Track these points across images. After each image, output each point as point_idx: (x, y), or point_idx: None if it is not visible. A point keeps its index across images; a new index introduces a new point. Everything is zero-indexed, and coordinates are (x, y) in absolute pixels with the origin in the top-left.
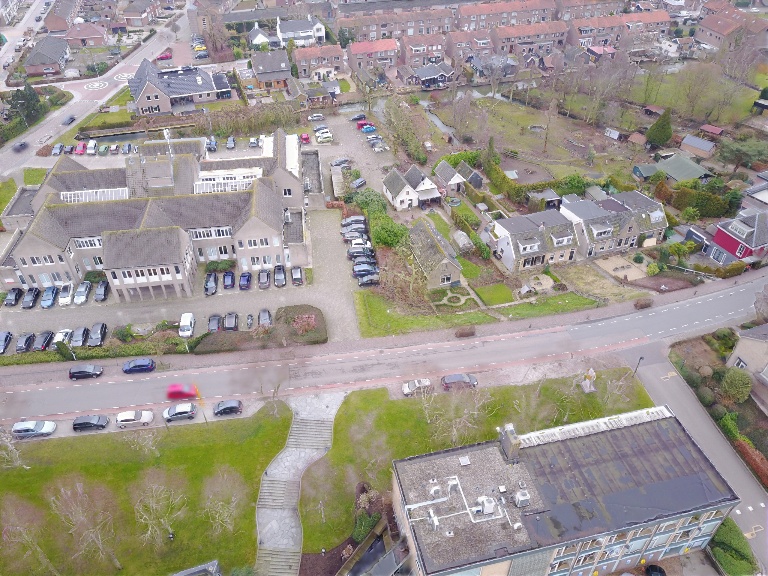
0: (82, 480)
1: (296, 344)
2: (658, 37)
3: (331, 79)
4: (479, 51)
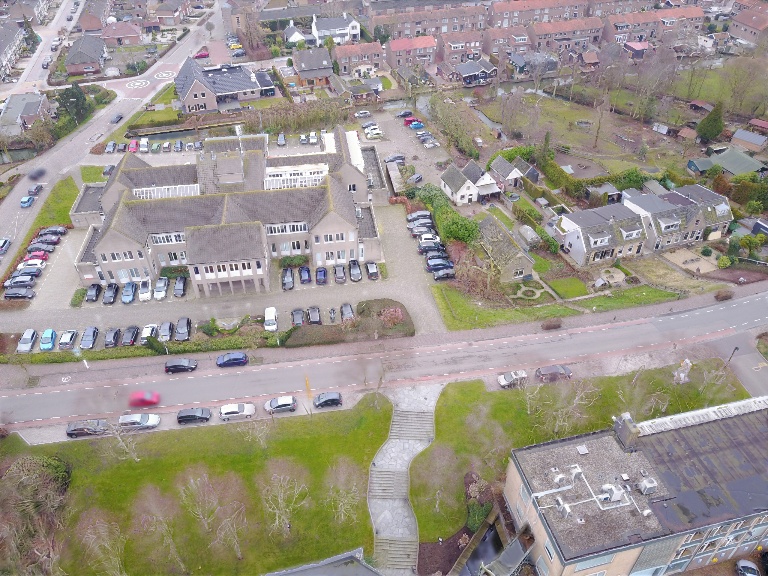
0: (192, 472)
1: (385, 337)
2: None
3: (371, 76)
4: (516, 47)
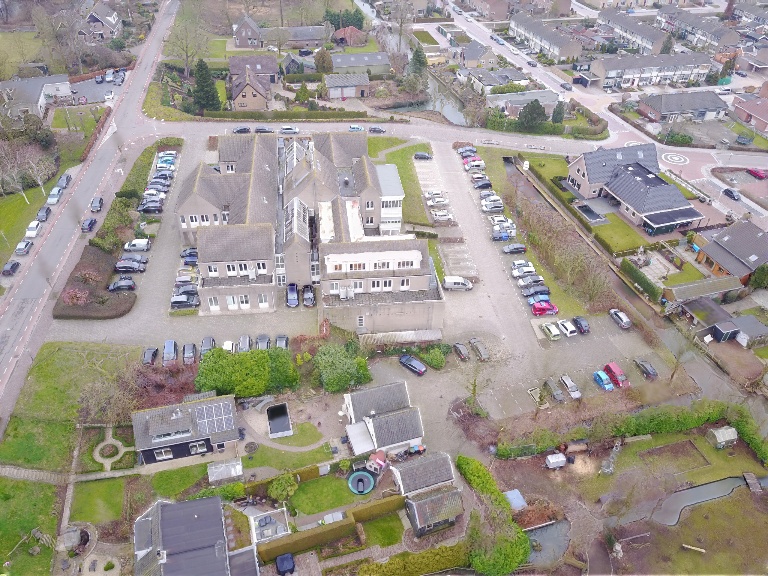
0: (7, 224)
1: None
2: None
3: None
4: None
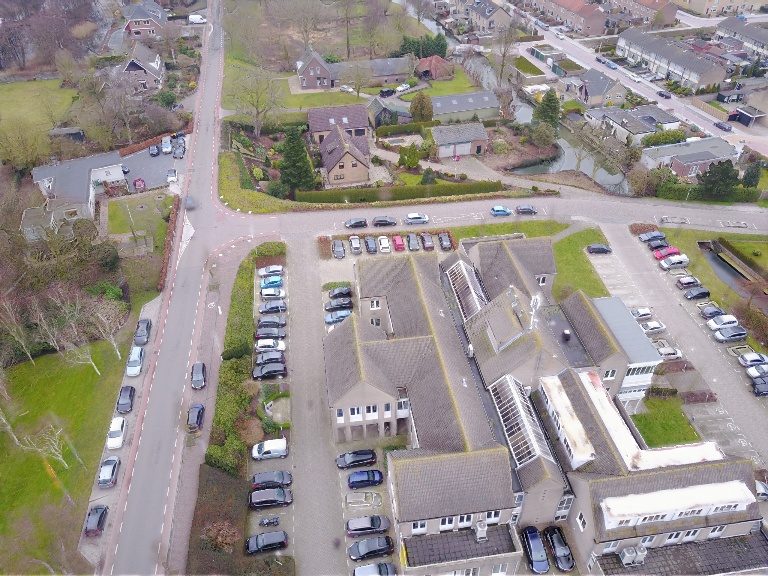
0: (74, 415)
1: None
2: None
3: None
4: None
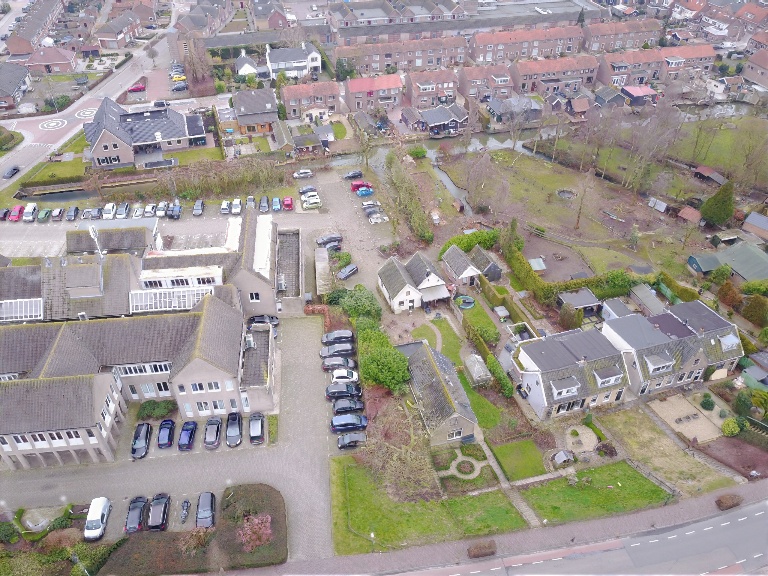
0: None
1: (242, 567)
2: (701, 74)
3: (325, 121)
4: (497, 89)
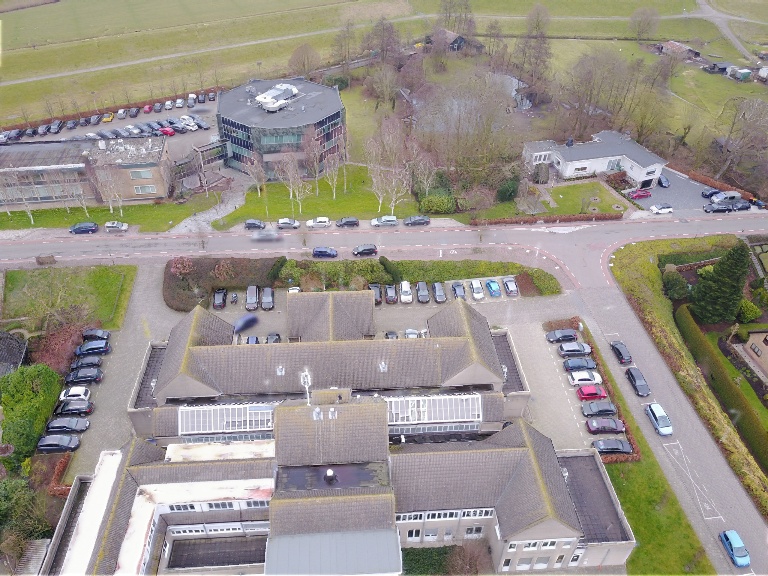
0: None
1: None
2: None
3: None
4: None
